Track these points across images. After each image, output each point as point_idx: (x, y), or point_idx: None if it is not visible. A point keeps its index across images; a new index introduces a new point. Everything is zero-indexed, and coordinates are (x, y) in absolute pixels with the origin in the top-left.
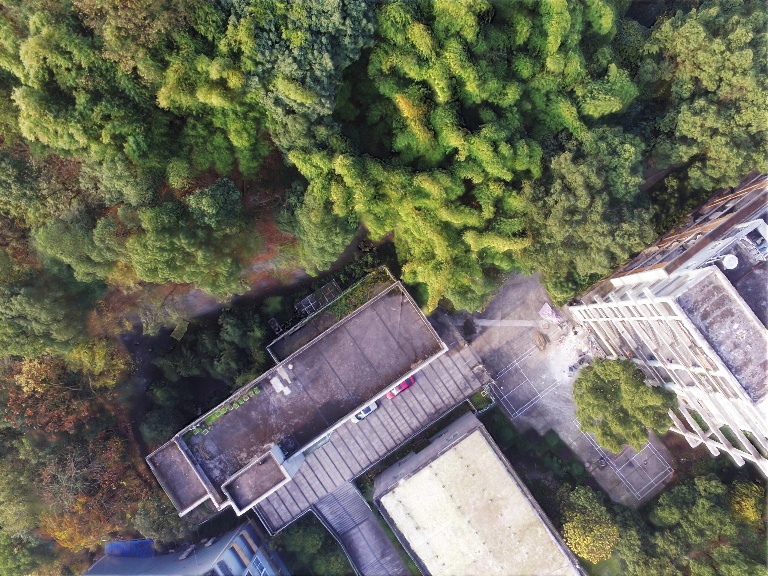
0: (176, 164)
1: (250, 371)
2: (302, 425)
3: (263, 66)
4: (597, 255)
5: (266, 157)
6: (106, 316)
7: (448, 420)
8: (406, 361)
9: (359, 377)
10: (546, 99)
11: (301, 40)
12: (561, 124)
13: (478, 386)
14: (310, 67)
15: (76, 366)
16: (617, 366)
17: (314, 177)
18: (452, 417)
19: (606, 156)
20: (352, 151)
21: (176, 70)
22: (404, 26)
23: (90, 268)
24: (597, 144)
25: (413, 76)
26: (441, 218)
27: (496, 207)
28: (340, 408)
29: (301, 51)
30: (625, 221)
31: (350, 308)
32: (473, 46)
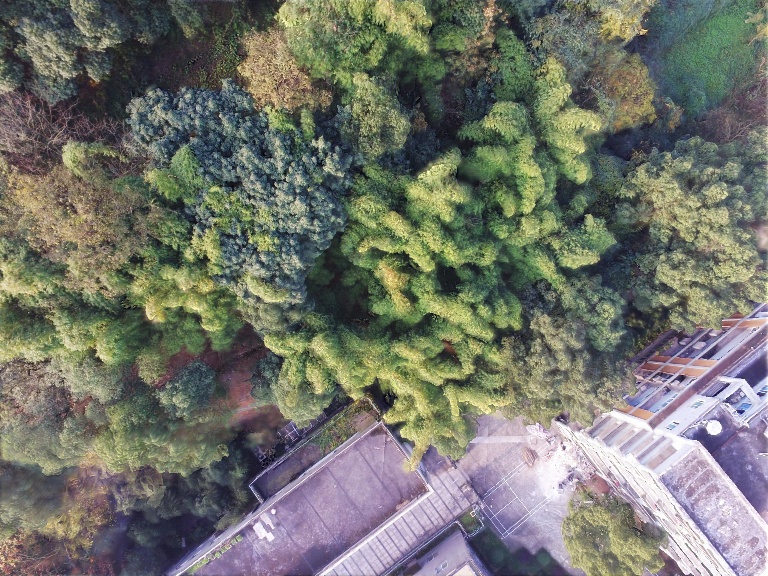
0: (145, 357)
1: (233, 512)
2: (287, 572)
3: (231, 268)
4: (580, 409)
5: (240, 329)
6: (79, 495)
7: (438, 539)
8: (391, 502)
9: (344, 520)
10: (523, 251)
11: (268, 245)
12: (539, 275)
13: (467, 506)
14: (279, 267)
15: (51, 533)
16: (605, 514)
17: (288, 356)
18: (442, 535)
19: (585, 314)
20: (327, 327)
21: (140, 284)
22: (375, 213)
23: (58, 465)
24: (576, 301)
25: (386, 250)
26: (421, 378)
27: (477, 356)
28: (325, 553)
29: (269, 256)
30: (607, 374)
31: (334, 439)
32: (446, 222)
